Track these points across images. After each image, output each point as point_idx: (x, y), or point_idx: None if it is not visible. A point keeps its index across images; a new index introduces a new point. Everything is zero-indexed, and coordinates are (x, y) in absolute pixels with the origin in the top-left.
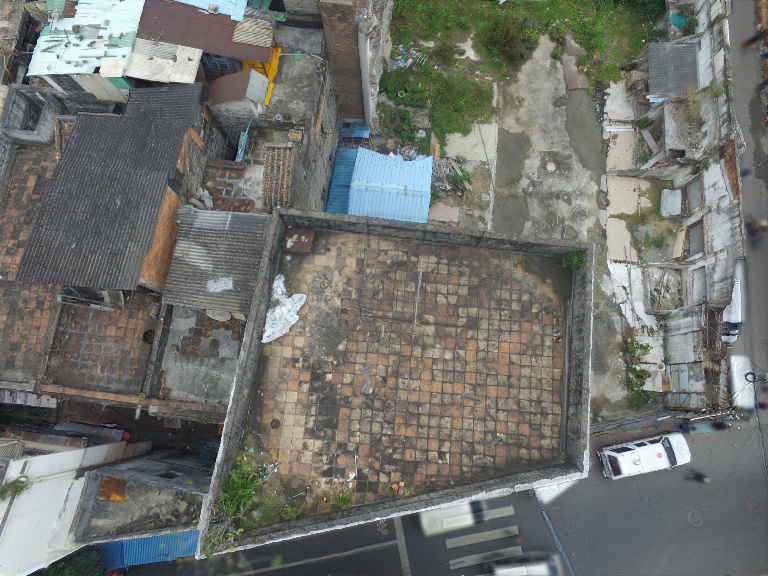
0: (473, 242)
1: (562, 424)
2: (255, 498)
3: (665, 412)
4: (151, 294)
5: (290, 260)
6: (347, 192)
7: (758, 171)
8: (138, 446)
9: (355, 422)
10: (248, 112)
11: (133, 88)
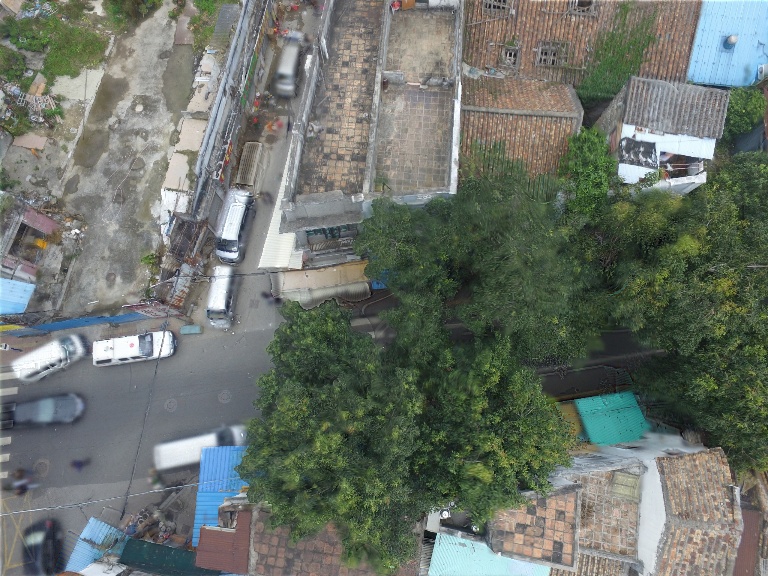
0: None
1: None
2: None
3: None
4: None
5: None
6: None
7: None
8: None
9: None
10: None
11: None
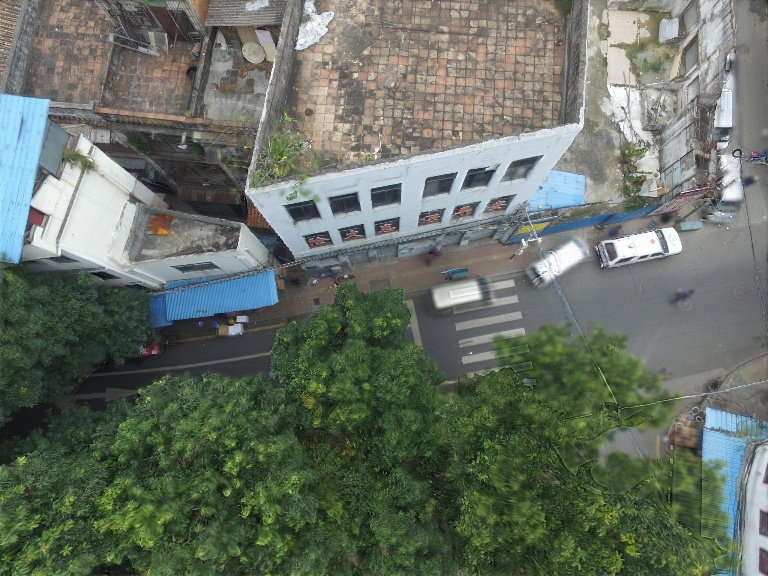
0: None
1: (561, 109)
2: (293, 166)
3: None
4: (193, 33)
5: None
6: None
7: (753, 5)
8: None
9: (379, 109)
10: None
11: None
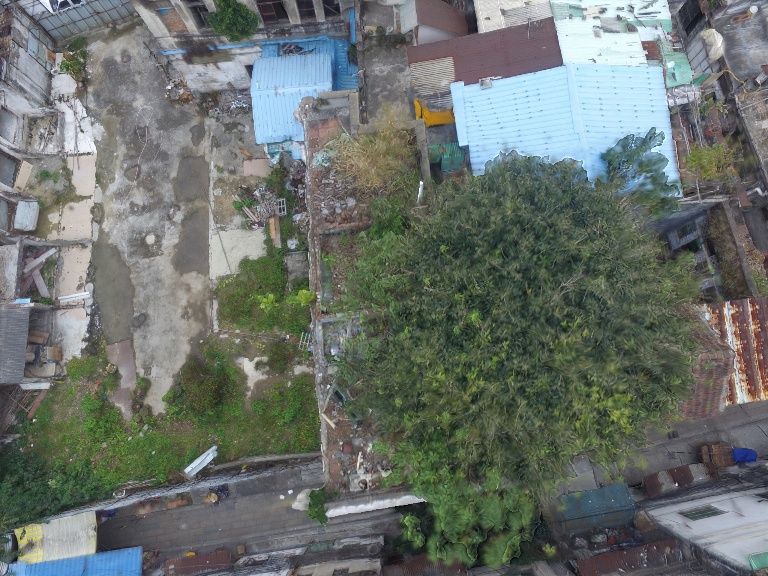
0: None
1: None
2: None
3: None
4: None
5: None
6: None
7: None
8: None
9: None
10: None
11: None
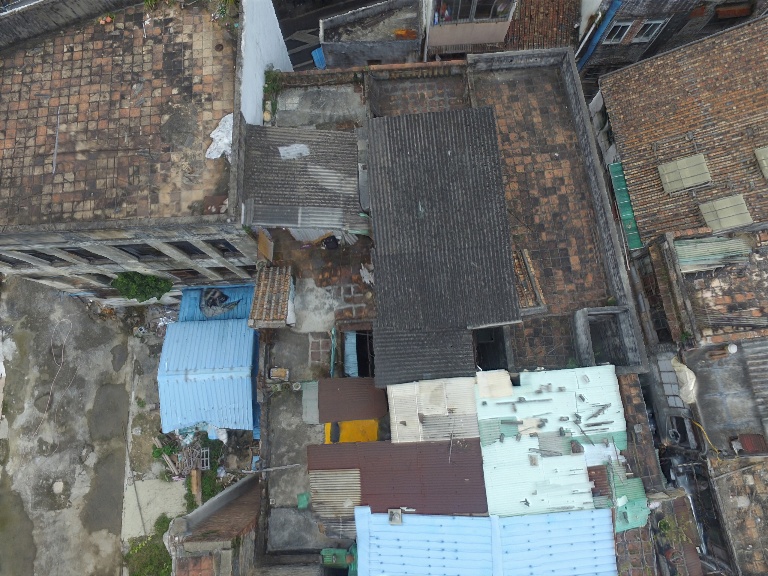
0: None
1: None
2: None
3: None
4: None
5: None
6: None
7: None
8: None
9: (148, 61)
10: None
11: None
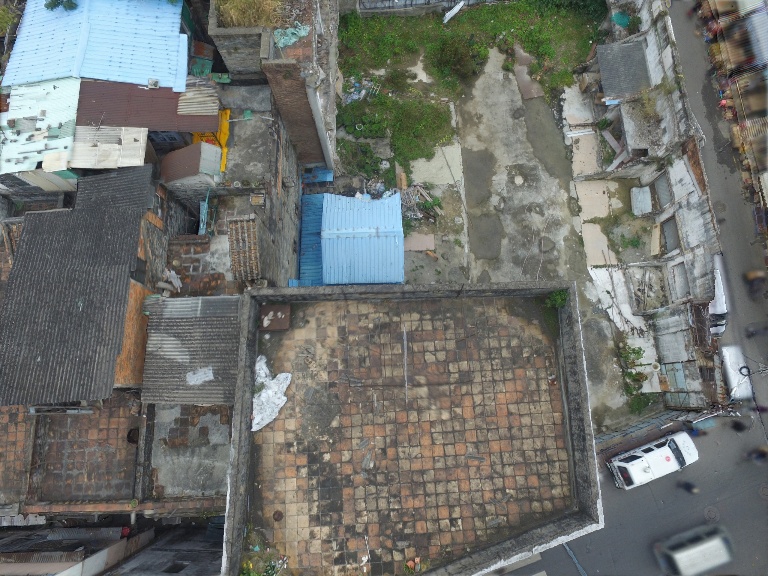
0: (453, 294)
1: (570, 470)
2: None
3: (667, 413)
4: (129, 391)
5: (269, 339)
6: (319, 240)
7: (720, 156)
8: (140, 538)
9: (360, 501)
10: (204, 184)
11: (80, 177)
